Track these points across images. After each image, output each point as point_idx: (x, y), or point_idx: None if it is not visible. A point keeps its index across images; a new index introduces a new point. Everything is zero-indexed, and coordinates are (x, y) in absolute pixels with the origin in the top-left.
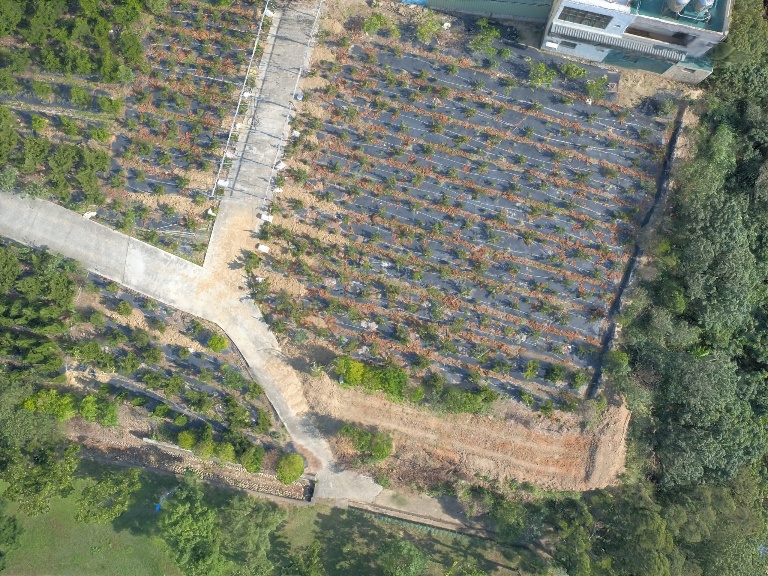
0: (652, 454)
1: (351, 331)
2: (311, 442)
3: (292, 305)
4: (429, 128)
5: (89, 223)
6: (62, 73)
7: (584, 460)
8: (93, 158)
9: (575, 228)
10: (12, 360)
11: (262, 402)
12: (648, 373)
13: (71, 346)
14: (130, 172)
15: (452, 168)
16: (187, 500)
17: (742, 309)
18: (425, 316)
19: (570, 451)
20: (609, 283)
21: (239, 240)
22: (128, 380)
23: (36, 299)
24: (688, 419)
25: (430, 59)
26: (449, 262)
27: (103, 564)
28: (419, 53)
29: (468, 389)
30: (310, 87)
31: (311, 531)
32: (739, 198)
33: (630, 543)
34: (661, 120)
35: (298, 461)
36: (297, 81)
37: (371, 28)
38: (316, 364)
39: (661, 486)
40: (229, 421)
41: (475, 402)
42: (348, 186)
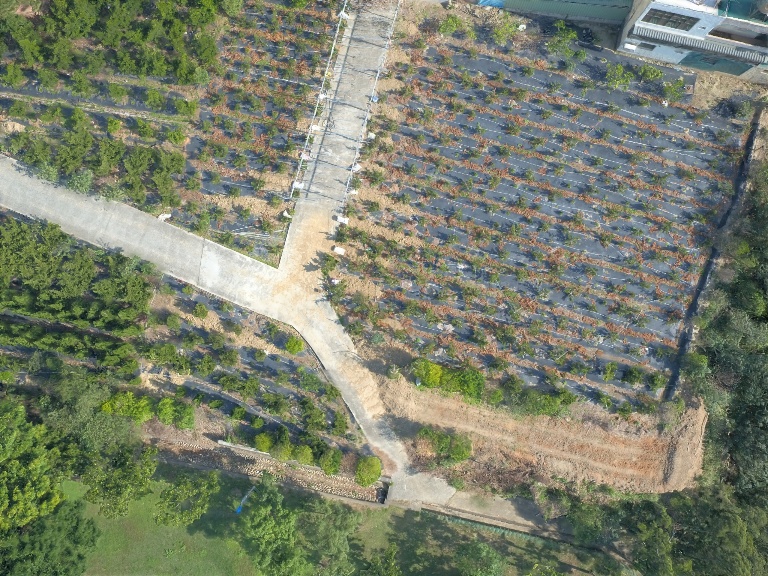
0: (727, 456)
1: (427, 333)
2: (387, 444)
3: (368, 307)
4: (505, 130)
5: (164, 225)
6: (136, 75)
7: (662, 462)
8: (169, 160)
9: (652, 230)
10: (86, 362)
11: (338, 404)
12: (728, 375)
13: (147, 348)
14: (205, 174)
15: (528, 170)
16: (268, 503)
17: None
18: (501, 318)
19: (648, 453)
20: (686, 285)
21: (315, 242)
22: (203, 382)
23: (112, 301)
24: (767, 421)
25: (505, 61)
26: (526, 264)
27: (177, 566)
28: (494, 55)
29: (545, 391)
30: (385, 89)
31: (385, 533)
32: None
33: (709, 545)
34: (737, 122)
35: (376, 463)
36: (375, 83)
37: (447, 30)
38: (396, 366)
39: (737, 488)
40: (305, 423)
41: (554, 404)
42: (424, 188)
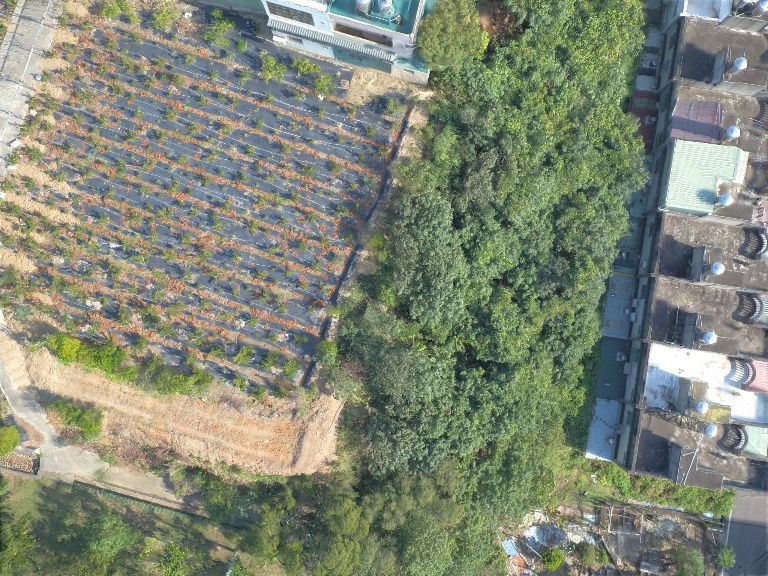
0: (369, 444)
1: (77, 309)
2: (32, 416)
3: (20, 281)
4: (163, 114)
5: None
6: None
7: (293, 446)
8: None
9: (299, 219)
10: None
11: None
12: (353, 364)
13: None
14: None
15: (182, 155)
16: None
17: (450, 306)
18: (149, 298)
19: (280, 436)
20: (329, 275)
21: None
22: None
23: None
24: (390, 410)
25: (169, 47)
26: (174, 246)
27: None
28: (159, 40)
29: (186, 371)
30: (50, 68)
31: (35, 504)
32: (460, 198)
33: None
34: (390, 119)
35: (10, 433)
36: (28, 61)
37: (109, 13)
38: (27, 339)
39: (373, 475)
40: None
41: (184, 384)
42: (82, 167)
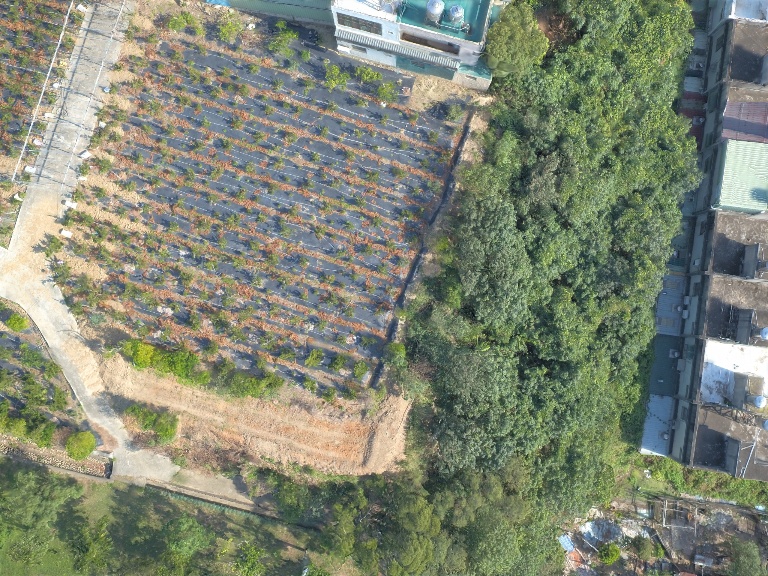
0: (435, 443)
1: (148, 316)
2: (106, 421)
3: (92, 289)
4: (230, 124)
5: None
6: None
7: (363, 446)
8: None
9: (364, 224)
10: None
11: (61, 381)
12: (422, 364)
13: None
14: None
15: (249, 163)
16: None
17: (515, 307)
18: (219, 304)
19: (350, 437)
20: (395, 278)
21: (44, 225)
22: None
23: None
24: (459, 409)
25: (234, 58)
26: (243, 253)
27: None
28: (224, 52)
29: (257, 375)
30: (118, 80)
31: (109, 507)
32: (521, 201)
33: None
34: (451, 124)
35: (87, 438)
36: (99, 74)
37: (176, 26)
38: (103, 345)
39: (441, 473)
40: None
41: (257, 387)
42: (150, 177)
